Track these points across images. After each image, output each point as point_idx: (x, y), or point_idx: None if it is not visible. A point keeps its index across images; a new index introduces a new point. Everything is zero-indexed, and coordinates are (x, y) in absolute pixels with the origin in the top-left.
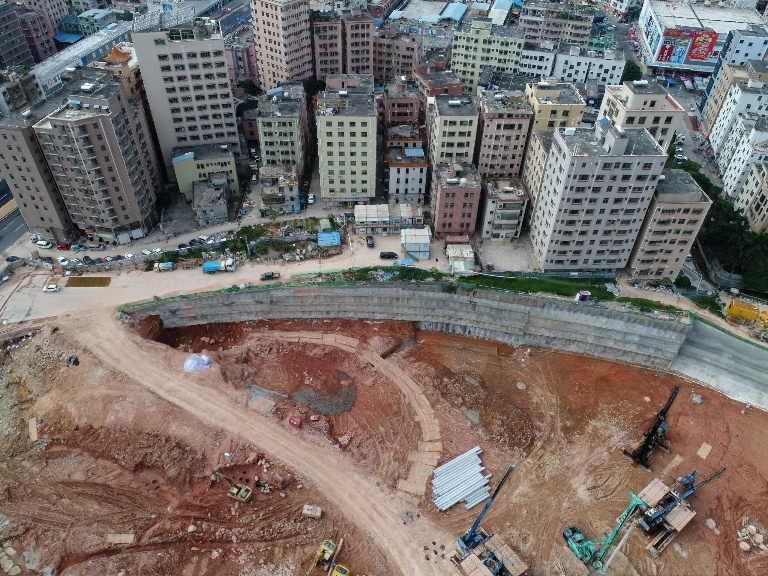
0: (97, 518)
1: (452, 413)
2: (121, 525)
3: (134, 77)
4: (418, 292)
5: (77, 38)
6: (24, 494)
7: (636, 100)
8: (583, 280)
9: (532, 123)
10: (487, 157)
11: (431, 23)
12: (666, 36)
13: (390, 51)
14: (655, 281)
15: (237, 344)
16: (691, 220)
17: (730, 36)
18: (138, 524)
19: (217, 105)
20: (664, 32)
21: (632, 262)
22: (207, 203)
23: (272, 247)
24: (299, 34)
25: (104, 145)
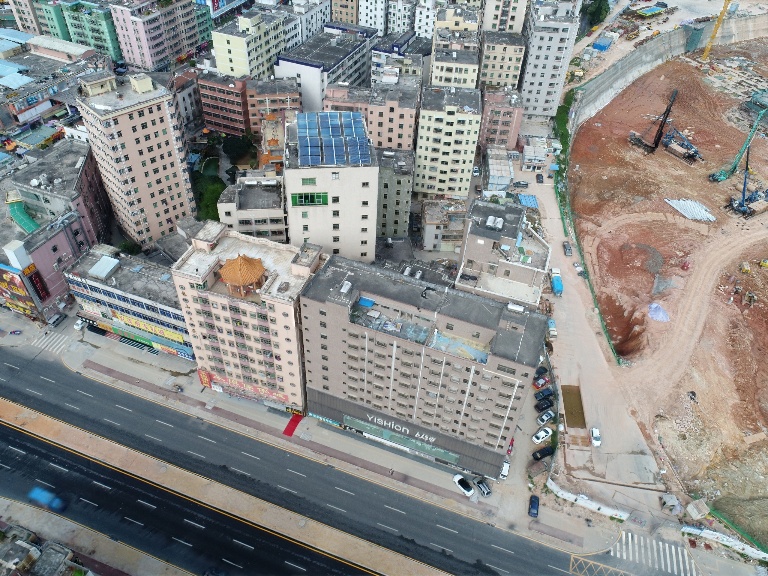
0: None
1: (641, 205)
2: None
3: None
4: None
5: None
6: None
7: None
8: None
9: None
10: None
11: (32, 83)
12: None
13: None
14: None
15: None
16: None
17: None
18: None
19: None
20: None
21: None
22: None
23: None
24: None
25: None
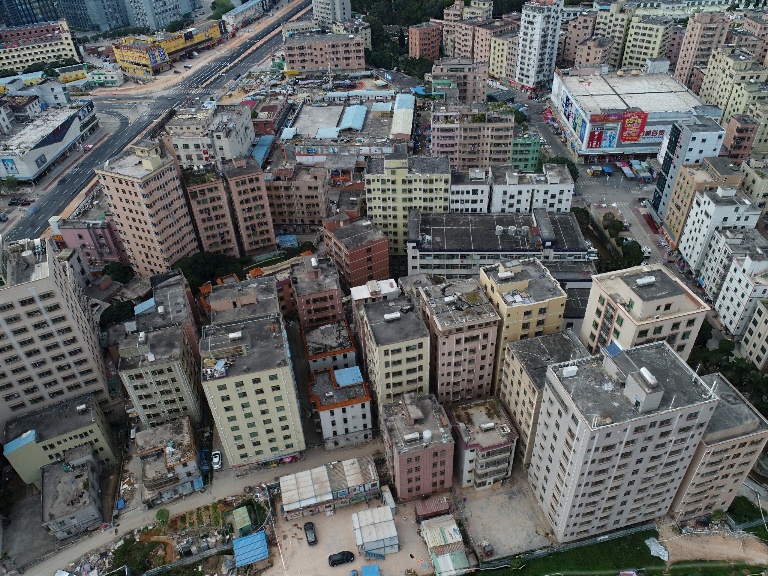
0: None
1: None
2: None
3: None
4: None
5: None
6: None
7: (646, 307)
8: (616, 543)
9: (501, 328)
10: (448, 375)
11: (330, 139)
12: (593, 123)
13: (289, 193)
14: (705, 517)
15: None
16: (748, 452)
17: (676, 130)
18: None
19: (61, 355)
20: (590, 119)
21: (675, 506)
22: (64, 507)
23: None
24: (170, 206)
25: None
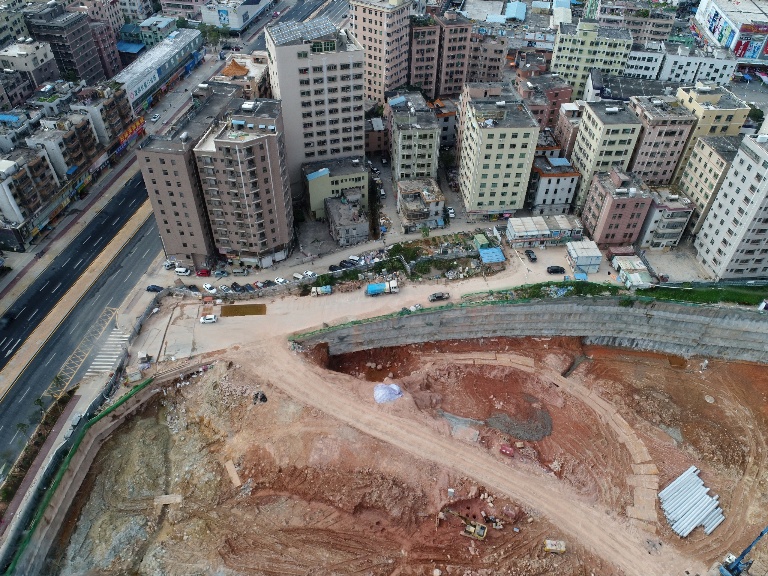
0: (333, 567)
1: (654, 432)
2: (361, 573)
3: (258, 91)
4: (593, 307)
5: (139, 48)
6: (246, 545)
7: None
8: (759, 288)
9: (693, 129)
10: (642, 164)
11: (499, 23)
12: (742, 32)
13: (477, 54)
14: None
15: (407, 369)
16: None
17: None
18: (378, 571)
19: (349, 118)
20: (741, 28)
21: None
22: (348, 221)
23: (434, 266)
24: (400, 40)
25: (266, 166)
